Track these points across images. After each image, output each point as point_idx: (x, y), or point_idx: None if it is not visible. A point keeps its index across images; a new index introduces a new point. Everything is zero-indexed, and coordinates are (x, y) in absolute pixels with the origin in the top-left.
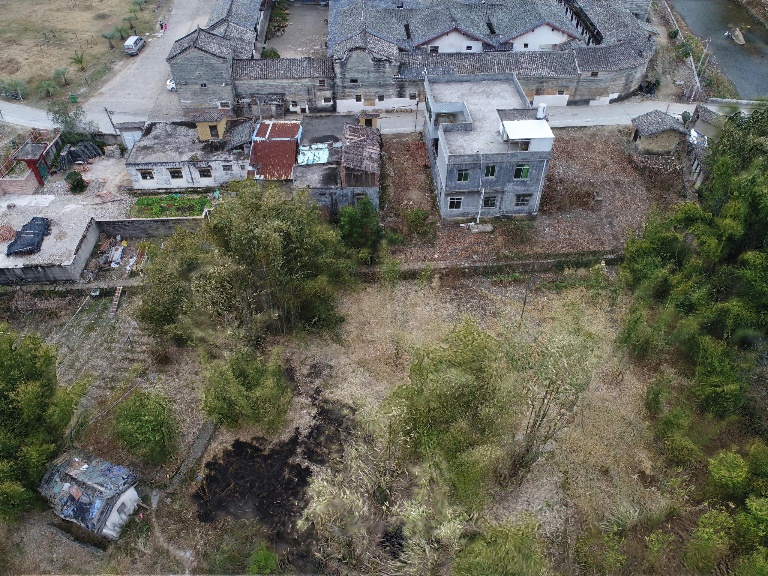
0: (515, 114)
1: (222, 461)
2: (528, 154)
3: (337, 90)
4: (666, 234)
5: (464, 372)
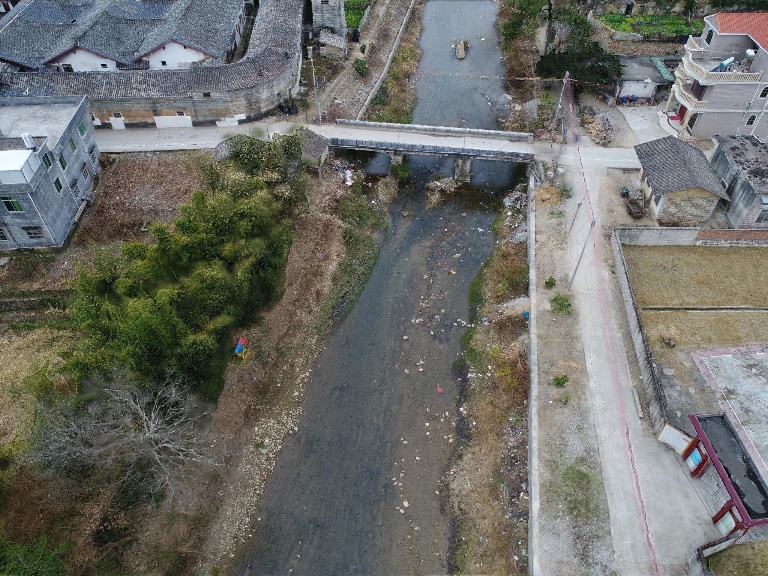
0: (12, 143)
1: None
2: (4, 187)
3: None
4: (92, 276)
5: None
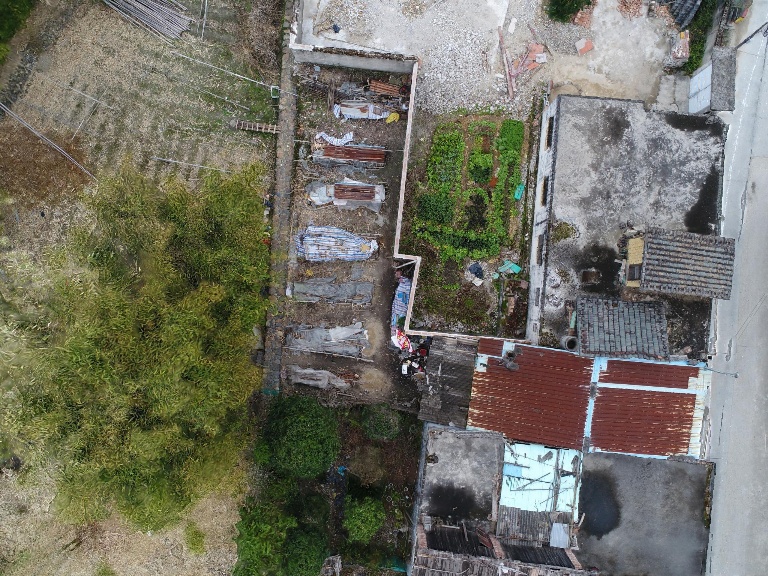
0: None
1: None
2: None
3: None
4: None
5: None
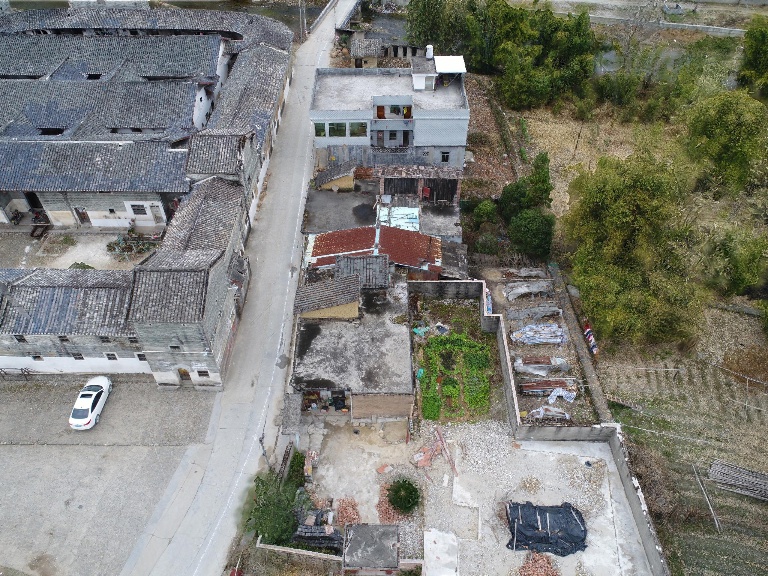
0: (421, 67)
1: (759, 301)
2: None
3: (246, 202)
4: None
5: (754, 101)
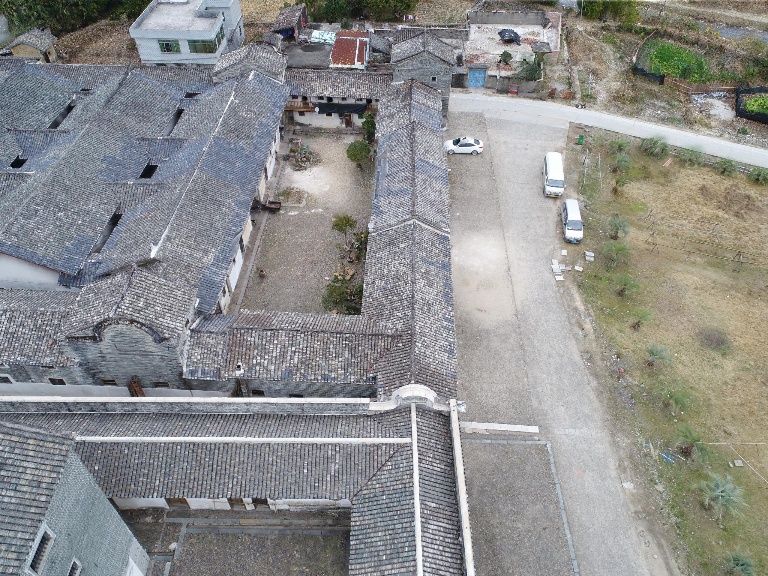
0: None
1: None
2: None
3: None
4: None
5: None
